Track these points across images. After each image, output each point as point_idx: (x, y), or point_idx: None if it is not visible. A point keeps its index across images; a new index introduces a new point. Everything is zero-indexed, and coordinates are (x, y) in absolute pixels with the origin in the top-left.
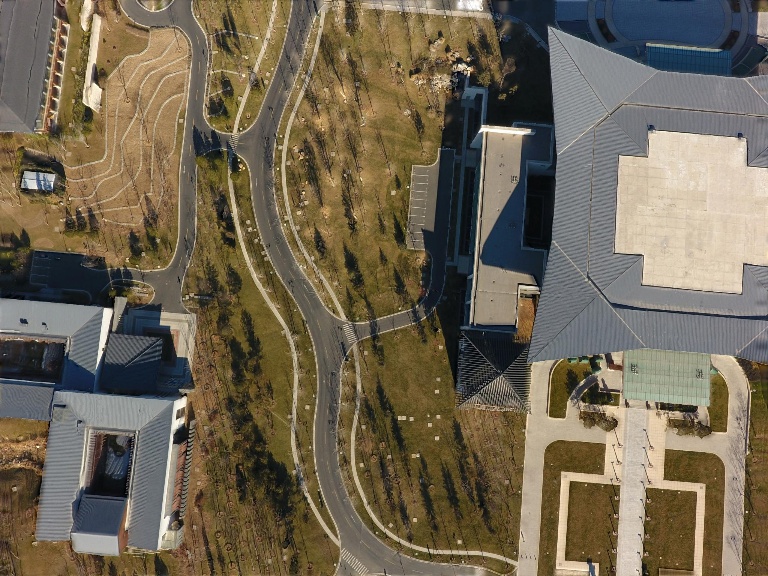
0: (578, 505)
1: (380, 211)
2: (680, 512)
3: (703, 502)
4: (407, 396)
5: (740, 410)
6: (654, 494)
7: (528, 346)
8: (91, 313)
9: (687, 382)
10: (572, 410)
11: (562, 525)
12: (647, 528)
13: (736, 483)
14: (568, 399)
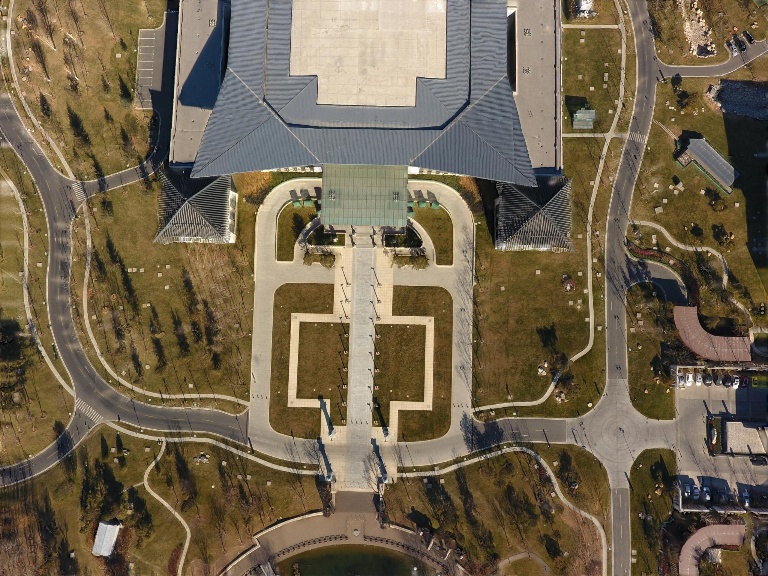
0: (308, 344)
1: (104, 73)
2: (409, 345)
3: (432, 334)
4: (137, 249)
5: (466, 243)
6: (383, 329)
7: (222, 177)
8: None
9: (384, 205)
10: (300, 253)
11: (293, 364)
12: (377, 363)
13: (464, 314)
14: (295, 242)
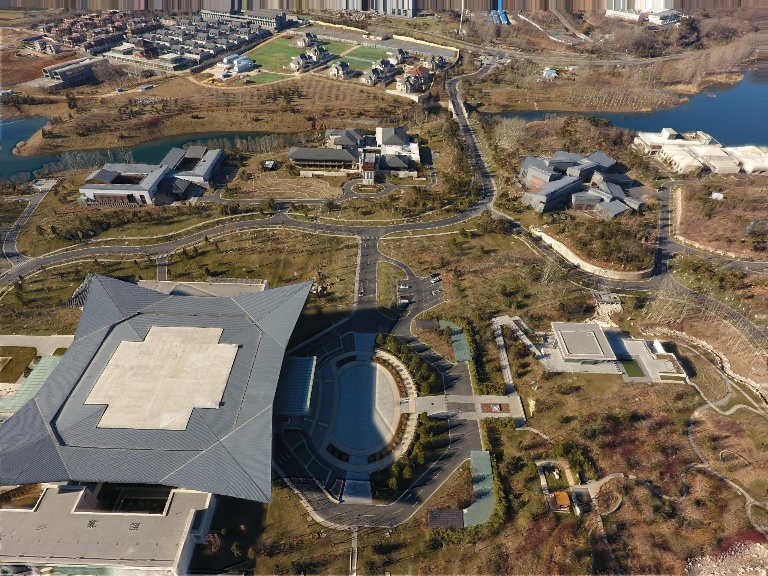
0: None
1: (233, 263)
2: None
3: None
4: None
5: None
6: None
7: None
8: (201, 174)
9: None
10: None
11: None
12: None
13: None
14: None
